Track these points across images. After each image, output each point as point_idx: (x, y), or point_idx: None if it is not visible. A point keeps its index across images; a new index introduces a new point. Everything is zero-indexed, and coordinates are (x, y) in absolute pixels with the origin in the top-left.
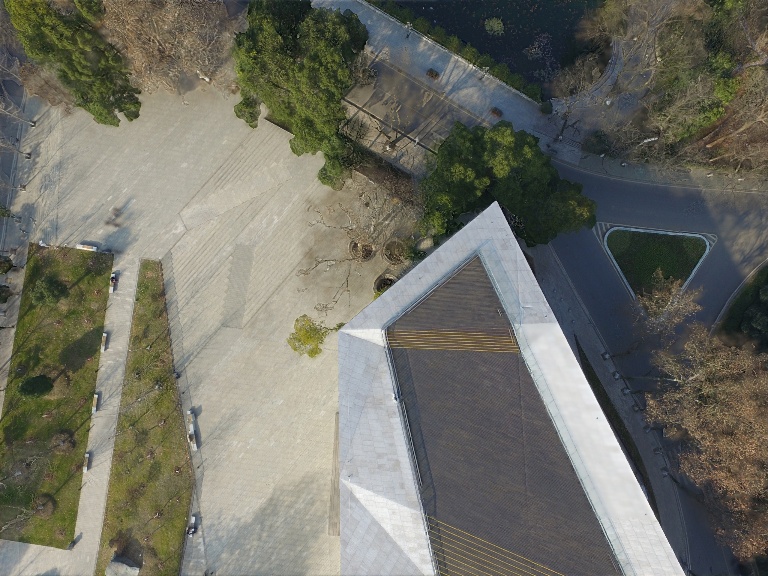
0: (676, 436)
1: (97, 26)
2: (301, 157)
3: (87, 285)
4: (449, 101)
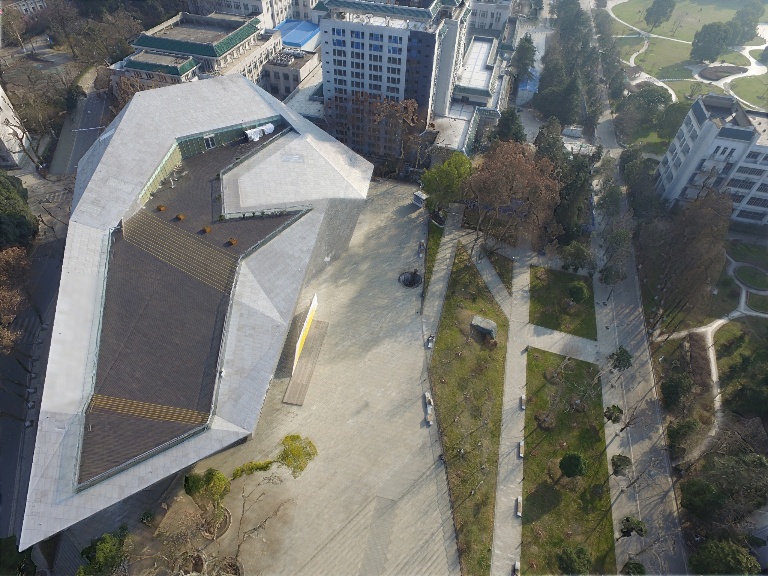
0: (15, 351)
1: None
2: None
3: (545, 575)
4: None
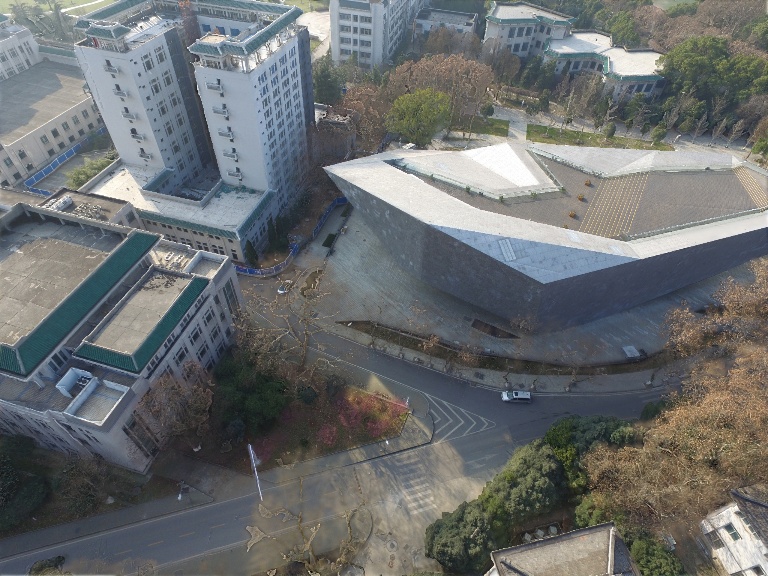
0: None
1: None
2: None
3: None
4: None
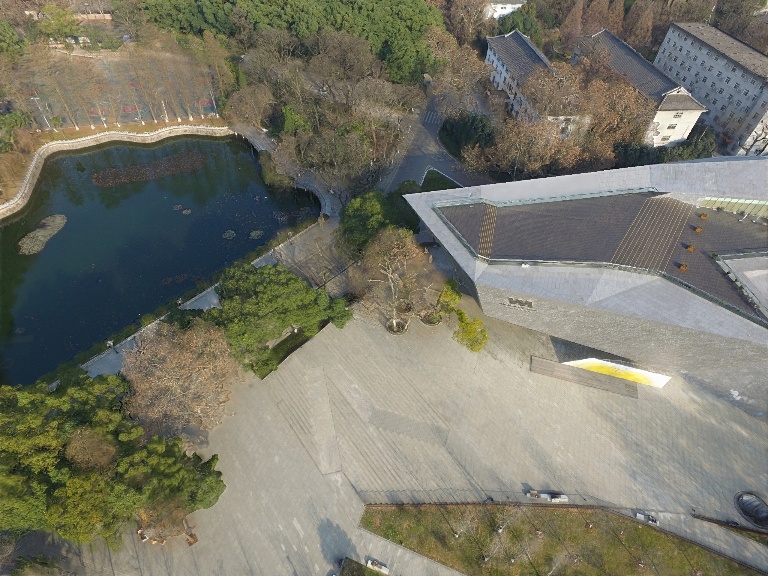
0: None
1: (145, 438)
2: (307, 356)
3: None
4: (299, 263)
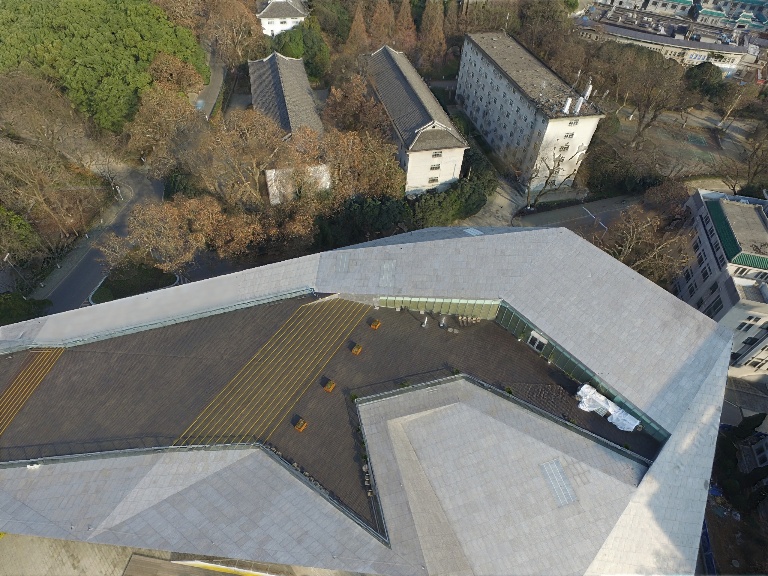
0: None
1: None
2: None
3: None
4: None
